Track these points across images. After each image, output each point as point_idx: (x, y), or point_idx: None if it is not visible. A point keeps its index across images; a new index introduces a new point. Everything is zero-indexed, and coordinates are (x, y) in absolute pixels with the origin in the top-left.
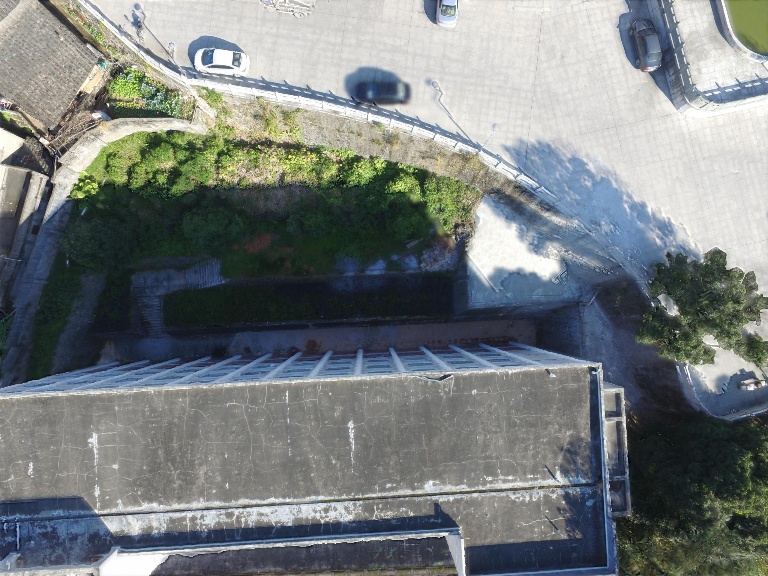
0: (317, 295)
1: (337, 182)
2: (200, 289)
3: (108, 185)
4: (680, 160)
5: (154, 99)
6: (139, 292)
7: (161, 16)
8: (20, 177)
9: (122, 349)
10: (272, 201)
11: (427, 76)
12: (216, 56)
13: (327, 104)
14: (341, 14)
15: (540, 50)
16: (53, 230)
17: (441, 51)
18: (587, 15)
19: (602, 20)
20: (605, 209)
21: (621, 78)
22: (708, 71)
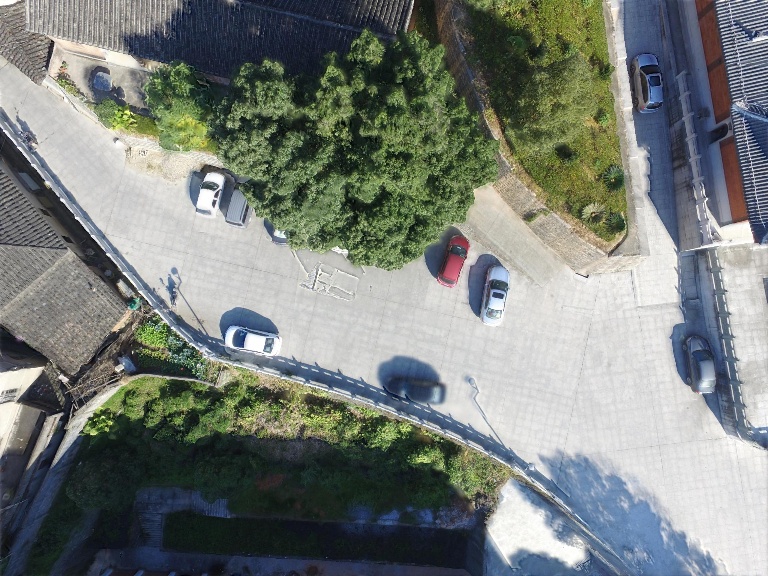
0: (324, 534)
1: (358, 440)
2: (204, 516)
3: (123, 415)
4: (725, 489)
5: (180, 355)
6: (141, 508)
7: (197, 283)
8: (34, 413)
9: (117, 554)
10: (289, 451)
11: (464, 371)
12: (248, 340)
13: (357, 399)
14: (382, 297)
15: (586, 355)
16: (61, 468)
17: (482, 346)
18: (639, 322)
19: (655, 329)
20: (640, 535)
21: (669, 393)
22: (764, 406)
